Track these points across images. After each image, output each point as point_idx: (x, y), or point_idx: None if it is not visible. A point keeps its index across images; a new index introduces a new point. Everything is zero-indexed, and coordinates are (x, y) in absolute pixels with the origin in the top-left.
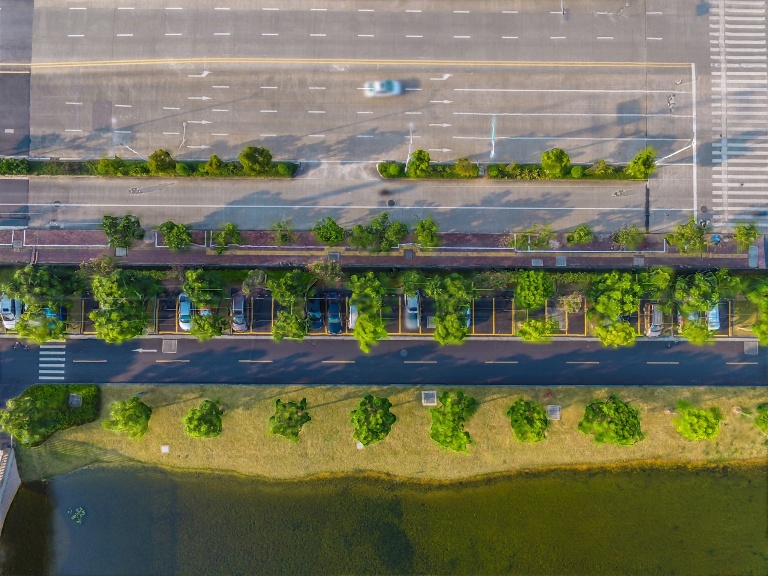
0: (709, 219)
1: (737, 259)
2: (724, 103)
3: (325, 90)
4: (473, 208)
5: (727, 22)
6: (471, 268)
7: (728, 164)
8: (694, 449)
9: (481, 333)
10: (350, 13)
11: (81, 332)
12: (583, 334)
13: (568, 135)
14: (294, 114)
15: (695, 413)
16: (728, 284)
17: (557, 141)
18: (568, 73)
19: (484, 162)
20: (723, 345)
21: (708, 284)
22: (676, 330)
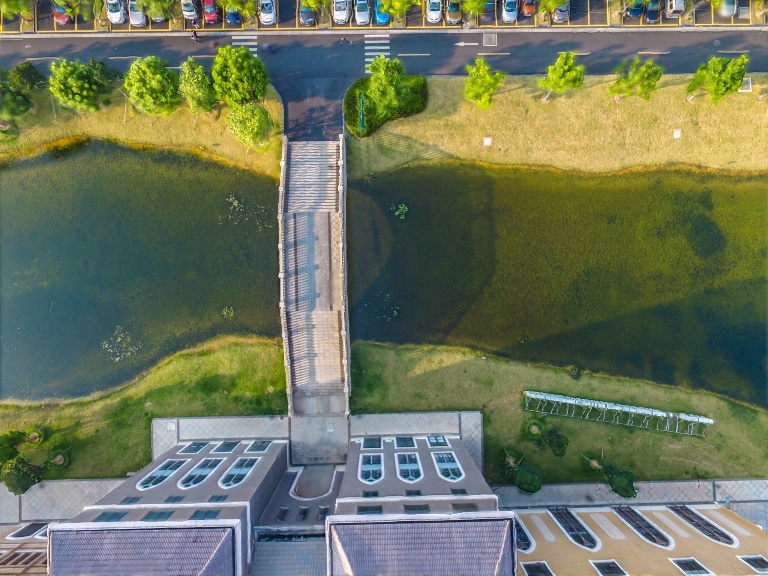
0: None
1: None
2: None
3: None
4: None
5: None
6: None
7: None
8: None
9: None
10: None
11: (404, 27)
12: None
13: None
14: None
15: None
16: None
17: None
18: None
19: None
20: None
21: None
22: None
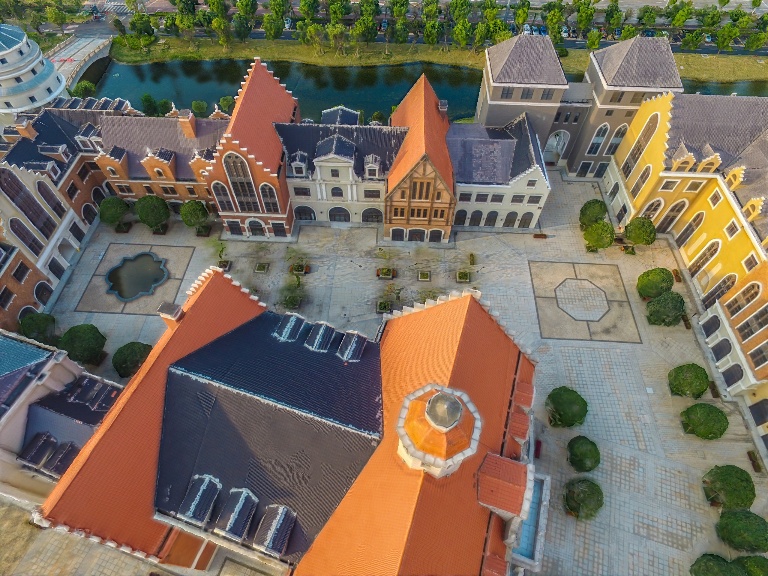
0: None
1: None
2: None
3: None
4: None
5: None
6: None
7: None
8: None
9: None
10: None
11: None
12: None
13: None
14: None
15: None
16: None
17: None
18: None
19: None
20: None
21: None
22: None
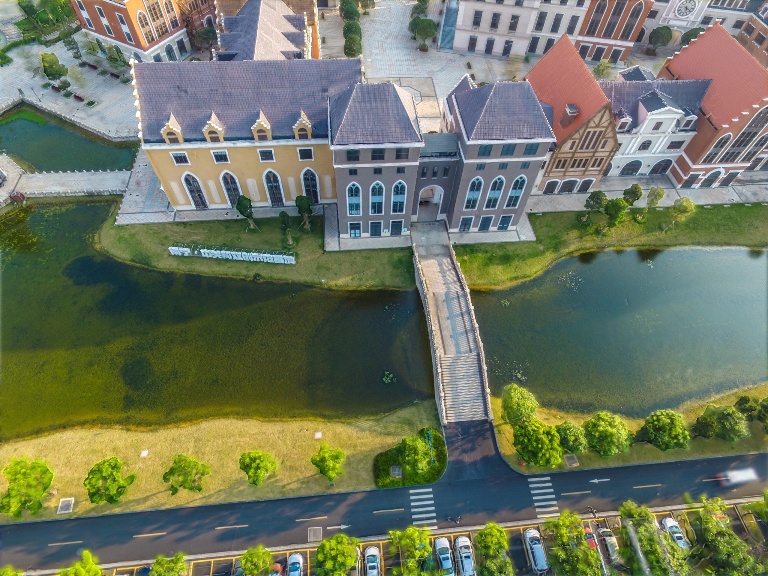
0: None
1: None
2: None
3: None
4: None
5: None
6: None
7: None
8: None
9: None
10: None
11: None
12: None
13: None
14: None
15: None
16: None
17: None
18: None
19: None
20: None
21: None
22: None
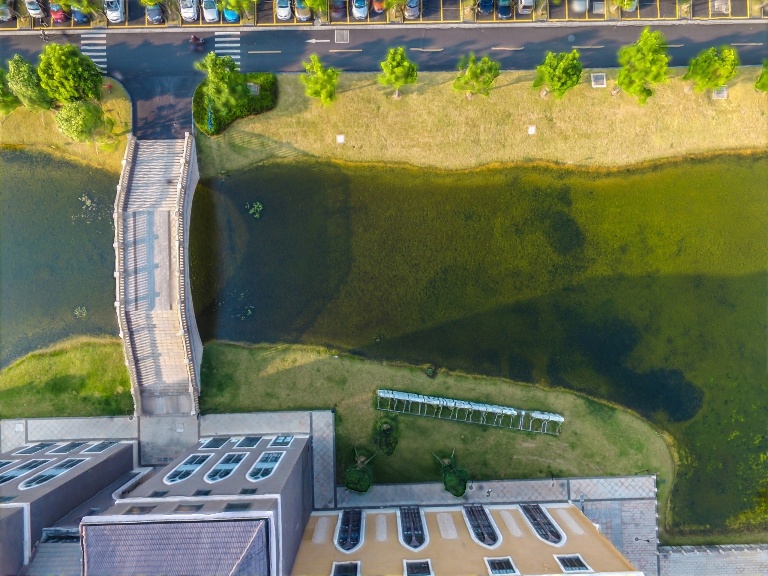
0: None
1: None
2: None
3: None
4: None
5: None
6: None
7: None
8: None
9: (646, 18)
10: None
11: (255, 24)
12: (746, 16)
13: None
14: None
15: None
16: None
17: None
18: None
19: None
20: None
21: None
22: None
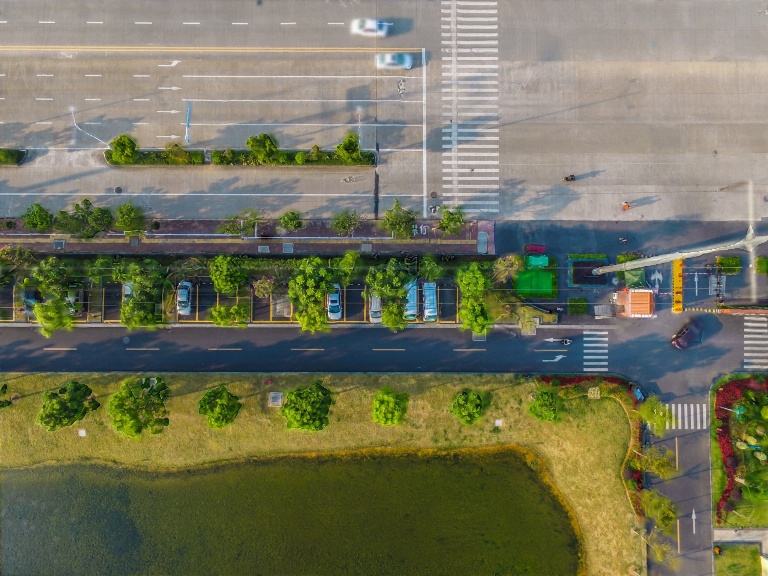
0: (439, 205)
1: (466, 245)
2: (455, 88)
3: (53, 77)
4: (201, 195)
5: (459, 7)
6: (195, 255)
7: (458, 149)
8: (422, 436)
9: (205, 320)
10: (80, 0)
11: None
12: None
13: (297, 121)
14: (22, 101)
15: (381, 398)
16: (427, 269)
17: (286, 127)
18: (297, 59)
19: (213, 149)
20: (451, 332)
21: (393, 268)
22: (401, 316)
